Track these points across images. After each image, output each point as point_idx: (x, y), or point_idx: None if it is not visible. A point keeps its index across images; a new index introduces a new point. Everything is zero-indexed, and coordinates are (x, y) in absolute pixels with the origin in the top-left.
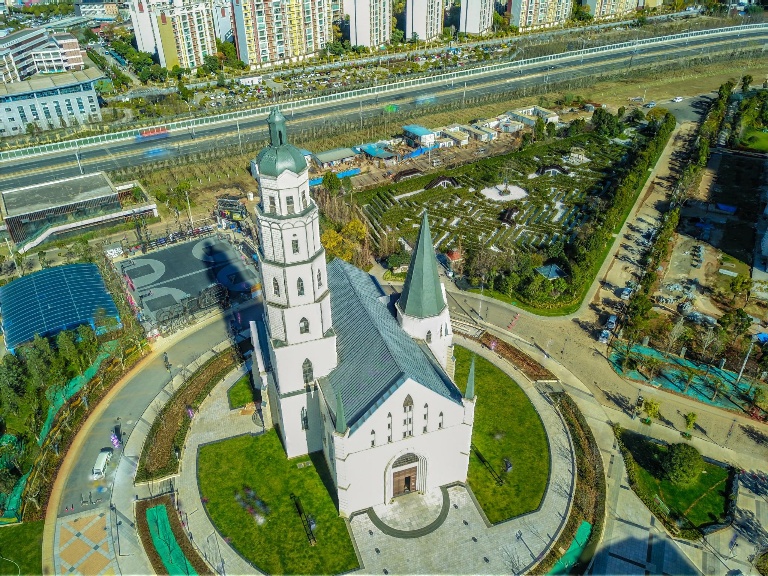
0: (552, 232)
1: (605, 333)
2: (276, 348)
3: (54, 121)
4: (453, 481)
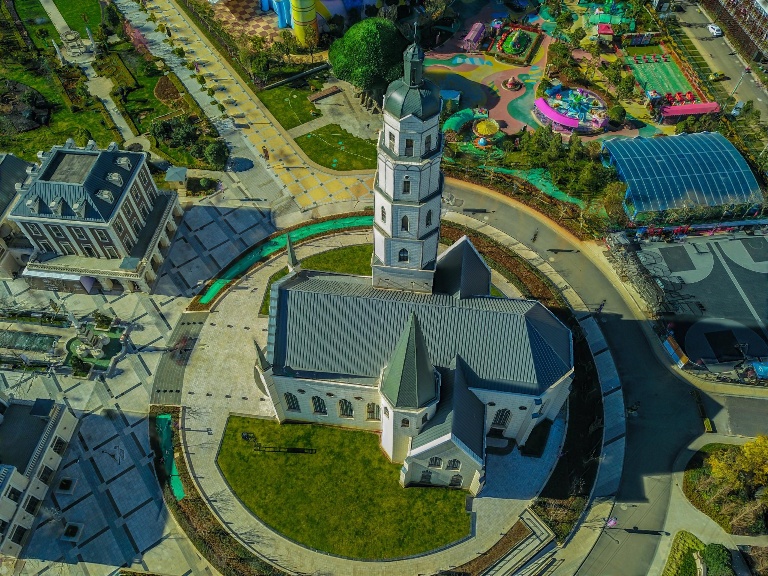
0: None
1: None
2: None
3: None
4: None
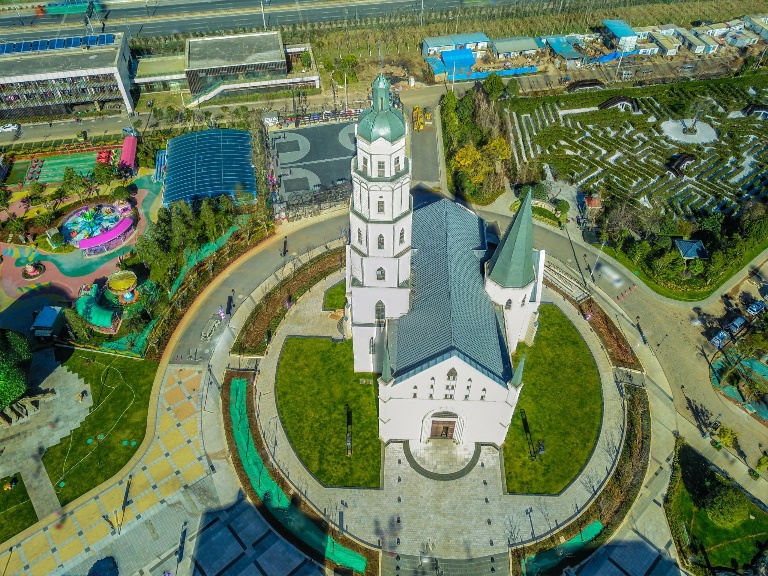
0: (722, 196)
1: (721, 336)
2: (353, 286)
3: None
4: (489, 441)
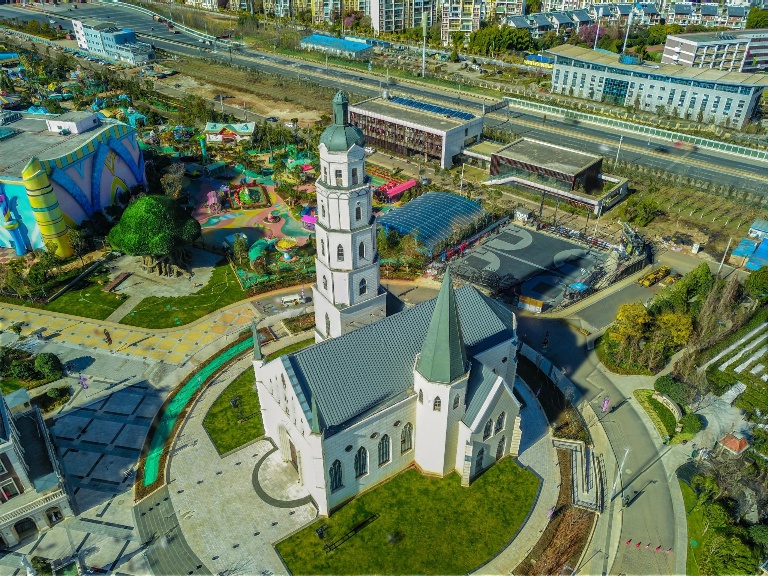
0: None
1: None
2: (312, 286)
3: (693, 112)
4: None
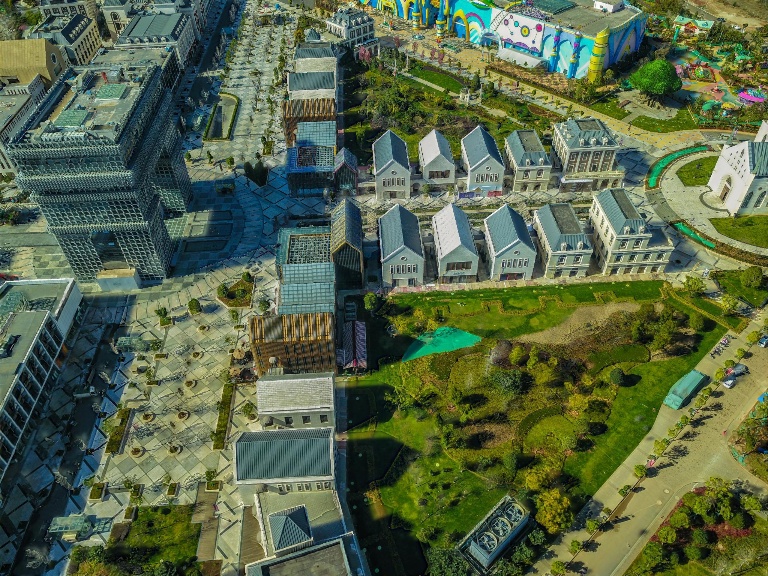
0: None
1: None
2: (764, 120)
3: None
4: None
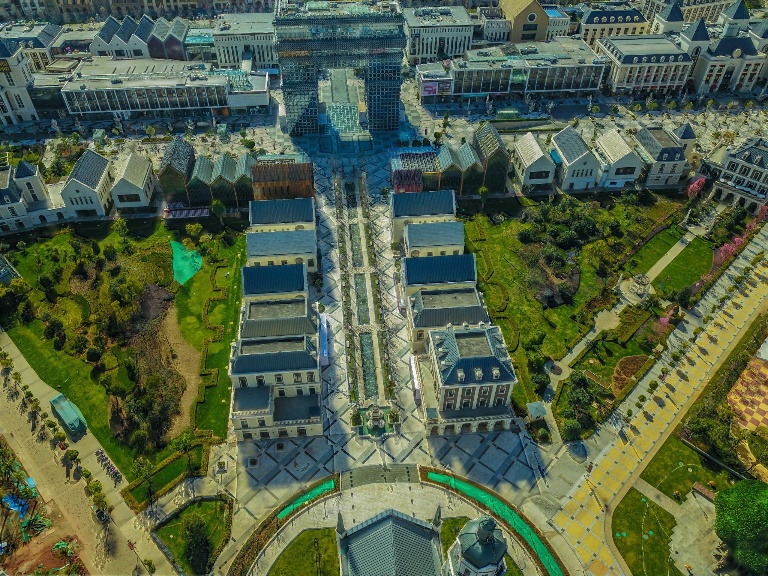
0: None
1: None
2: None
3: None
4: None
